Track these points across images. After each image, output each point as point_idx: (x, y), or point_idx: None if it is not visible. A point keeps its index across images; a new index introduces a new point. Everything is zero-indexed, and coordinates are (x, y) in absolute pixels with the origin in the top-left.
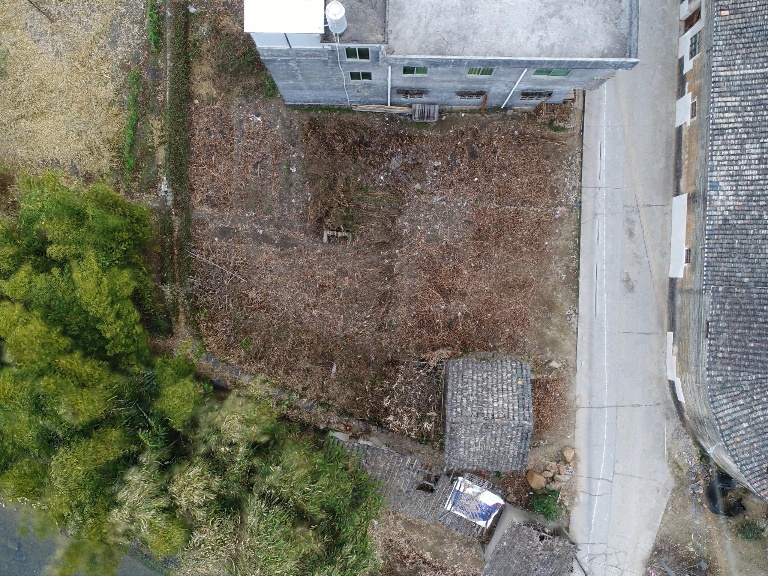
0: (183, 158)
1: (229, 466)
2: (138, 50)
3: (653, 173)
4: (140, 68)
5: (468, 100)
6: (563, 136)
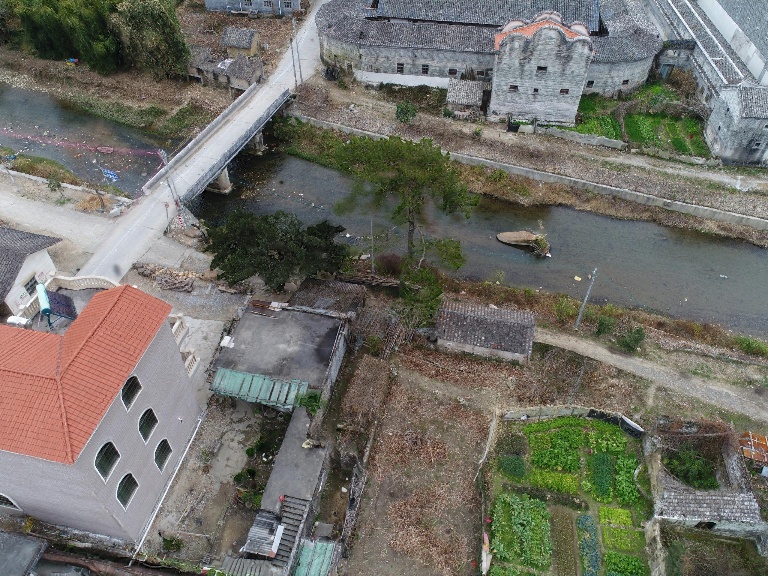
0: None
1: None
2: None
3: None
4: None
5: (268, 8)
6: None
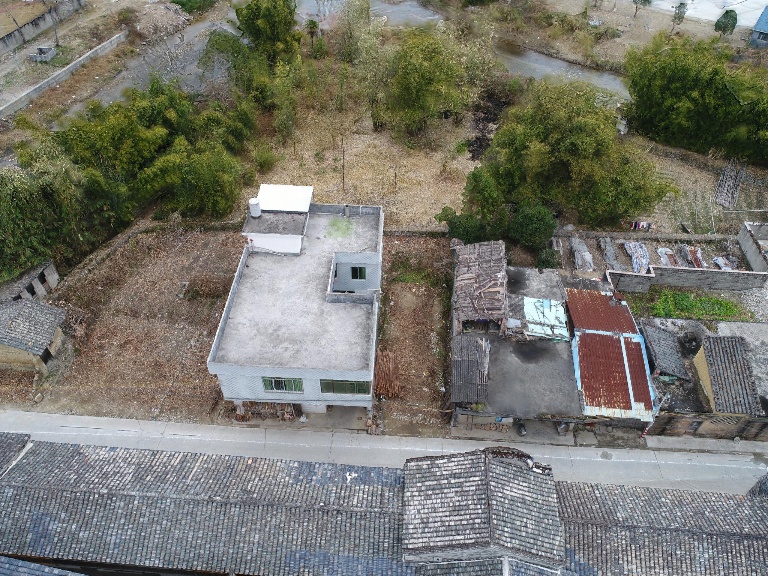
0: None
1: (44, 174)
2: None
3: None
4: None
5: None
6: (214, 416)
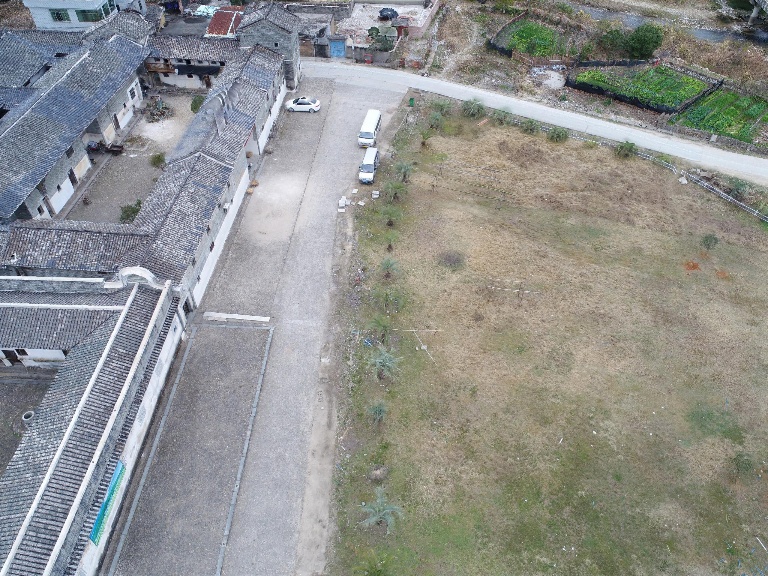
0: None
1: None
2: None
3: None
4: None
5: None
6: None
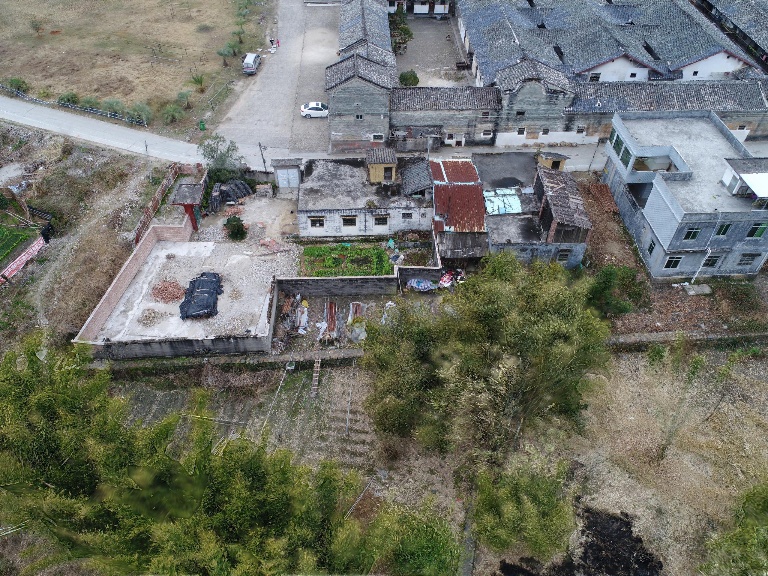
0: None
1: None
2: (764, 364)
3: None
4: None
5: None
6: None
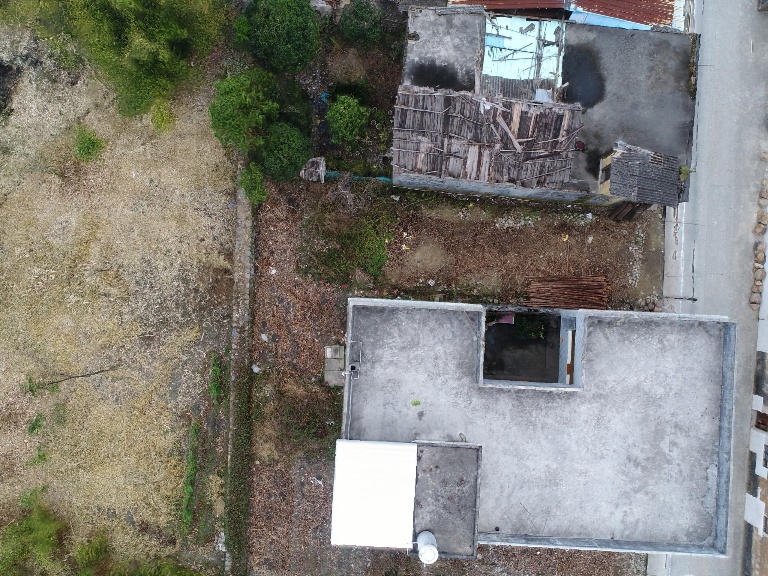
0: (243, 525)
1: None
2: (199, 400)
3: (720, 564)
4: (200, 419)
5: None
6: None
